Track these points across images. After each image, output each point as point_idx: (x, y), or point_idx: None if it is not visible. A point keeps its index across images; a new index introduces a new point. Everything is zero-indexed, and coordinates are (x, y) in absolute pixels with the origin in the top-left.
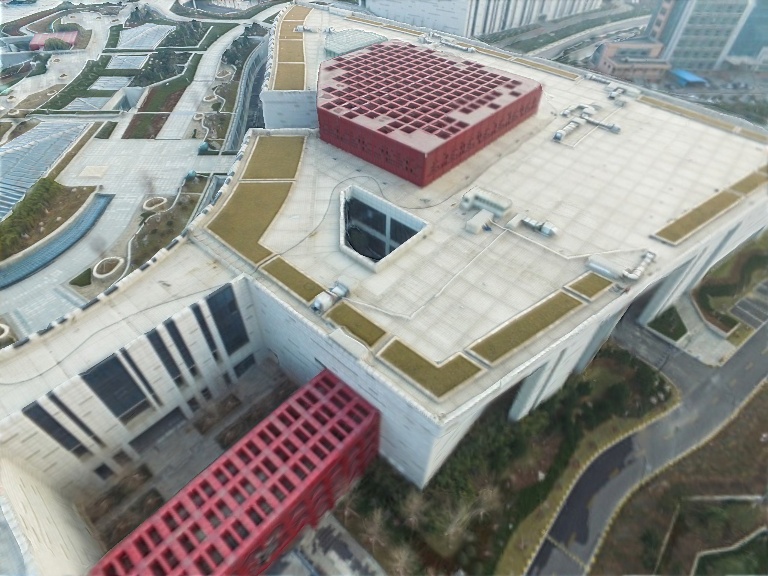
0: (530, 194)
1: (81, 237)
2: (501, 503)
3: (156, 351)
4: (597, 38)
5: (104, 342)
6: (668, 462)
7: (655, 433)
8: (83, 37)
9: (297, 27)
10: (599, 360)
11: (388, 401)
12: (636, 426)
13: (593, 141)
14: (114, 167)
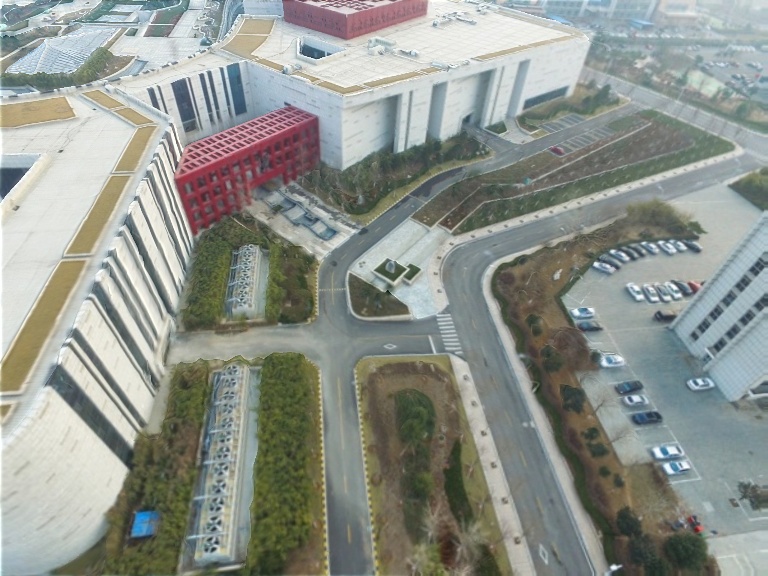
0: (410, 44)
1: None
2: (385, 179)
3: (202, 87)
4: None
5: (176, 79)
6: (479, 174)
7: (476, 165)
8: None
9: None
10: (451, 139)
11: (321, 102)
12: (466, 163)
13: (457, 27)
14: (143, 49)
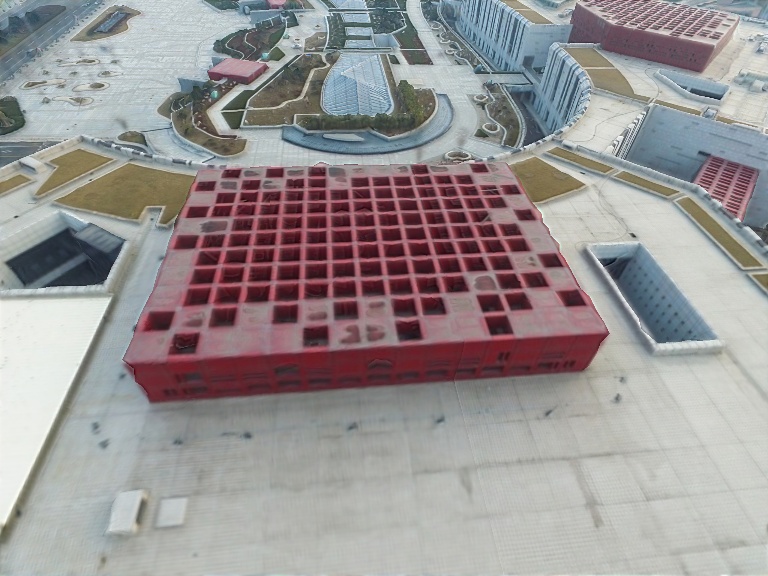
0: None
1: (452, 115)
2: None
3: None
4: None
5: (607, 129)
6: None
7: None
8: None
9: None
10: None
11: None
12: None
13: None
14: (426, 80)
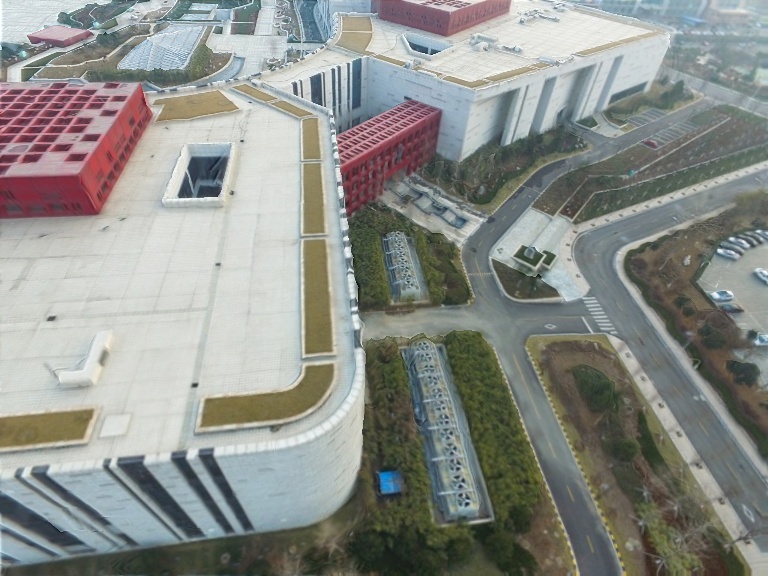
0: (507, 41)
1: (237, 73)
2: (499, 171)
3: (332, 82)
4: None
5: (309, 74)
6: (583, 166)
7: (577, 158)
8: None
9: None
10: (548, 132)
11: (448, 95)
12: (567, 156)
13: (543, 24)
14: (236, 46)
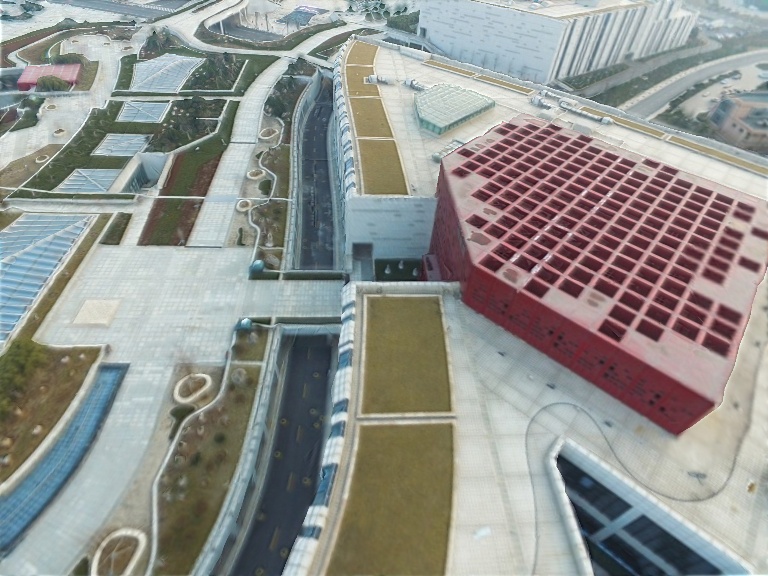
0: None
1: (73, 469)
2: None
3: None
4: (700, 85)
5: None
6: None
7: None
8: (87, 72)
9: (369, 77)
10: None
11: None
12: None
13: None
14: (127, 303)
